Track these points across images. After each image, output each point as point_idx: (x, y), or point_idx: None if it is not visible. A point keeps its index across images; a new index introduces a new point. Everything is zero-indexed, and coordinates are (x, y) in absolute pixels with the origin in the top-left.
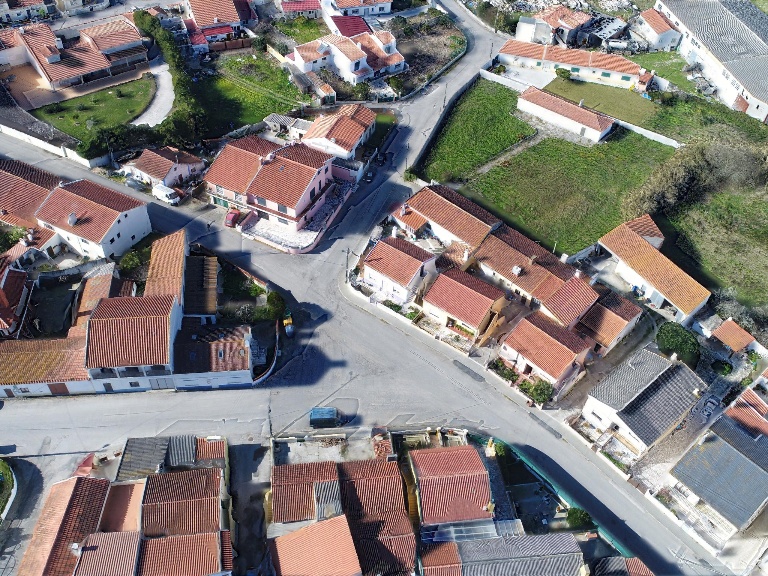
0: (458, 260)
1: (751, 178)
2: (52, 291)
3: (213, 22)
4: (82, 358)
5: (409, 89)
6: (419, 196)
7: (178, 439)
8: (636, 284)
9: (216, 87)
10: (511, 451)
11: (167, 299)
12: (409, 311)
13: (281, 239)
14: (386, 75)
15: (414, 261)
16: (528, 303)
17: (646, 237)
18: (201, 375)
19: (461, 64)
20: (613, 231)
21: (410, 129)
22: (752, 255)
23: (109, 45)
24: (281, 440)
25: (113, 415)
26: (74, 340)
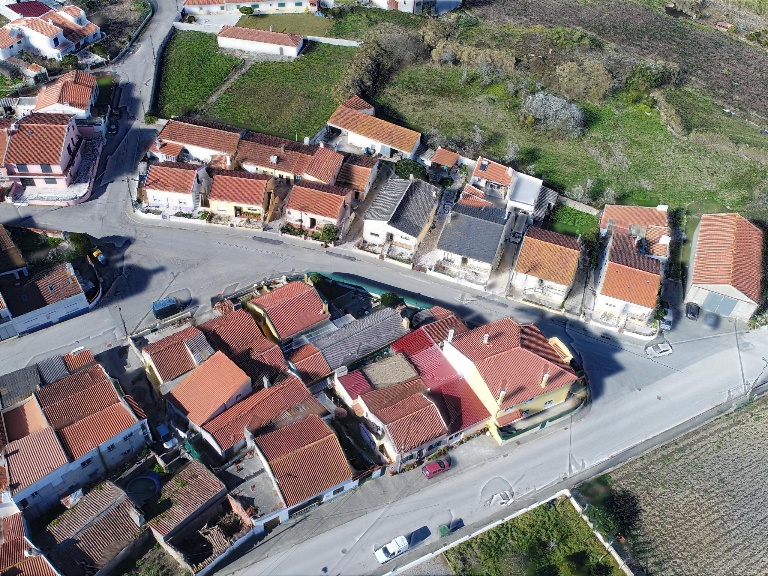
0: (223, 167)
1: (419, 55)
2: None
3: None
4: None
5: (115, 53)
6: (167, 129)
7: (45, 363)
8: (367, 146)
9: None
10: (324, 278)
11: None
12: (200, 215)
13: (55, 197)
14: (87, 46)
15: (188, 172)
16: (292, 182)
17: (361, 110)
18: (39, 312)
19: (153, 23)
20: (335, 113)
21: (132, 84)
22: (439, 106)
23: None
24: (137, 335)
25: None
26: None
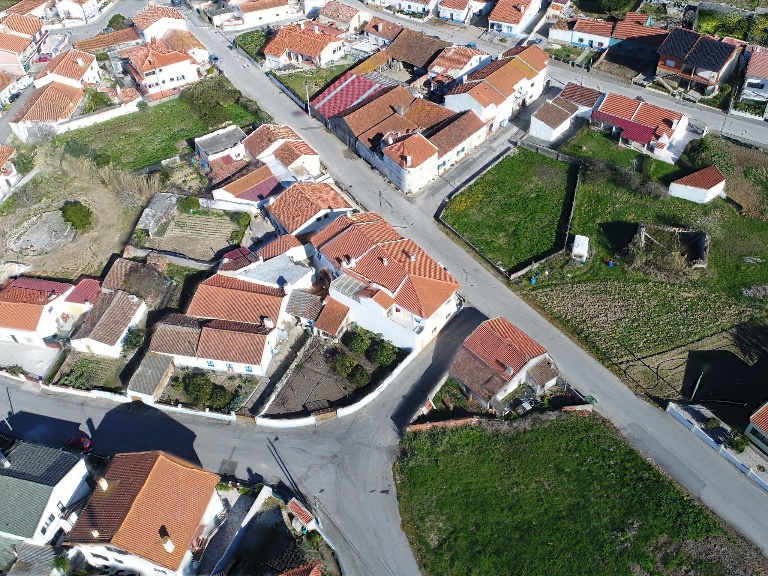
0: None
1: None
2: None
3: None
4: None
5: None
6: None
7: None
8: None
9: None
10: None
11: None
12: None
13: (58, 45)
14: None
15: None
16: None
17: None
18: None
19: None
20: None
21: None
22: None
23: None
24: None
25: (201, 36)
26: None
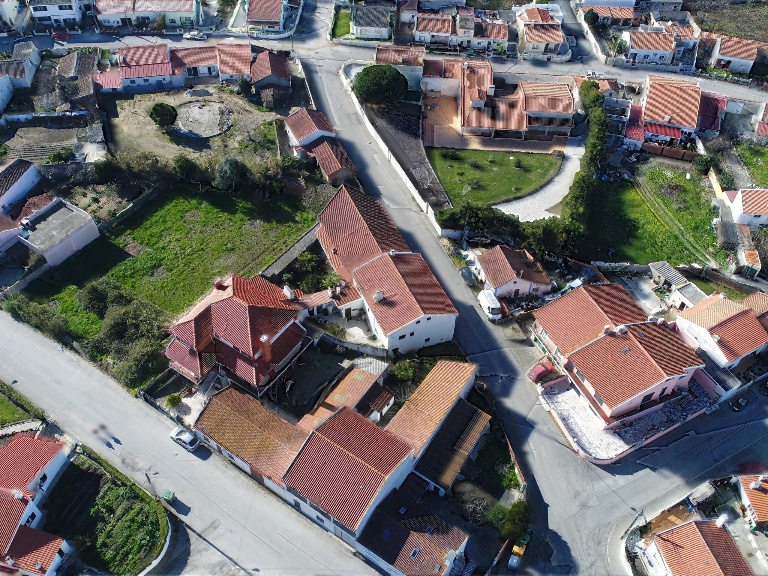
0: None
1: None
2: (324, 356)
3: (663, 119)
4: (290, 461)
5: None
6: None
7: None
8: None
9: (622, 196)
10: None
11: (401, 449)
12: None
13: (579, 429)
14: None
15: None
16: None
17: None
18: None
19: None
20: None
21: None
22: None
23: (538, 108)
24: None
25: (284, 538)
26: (298, 433)
